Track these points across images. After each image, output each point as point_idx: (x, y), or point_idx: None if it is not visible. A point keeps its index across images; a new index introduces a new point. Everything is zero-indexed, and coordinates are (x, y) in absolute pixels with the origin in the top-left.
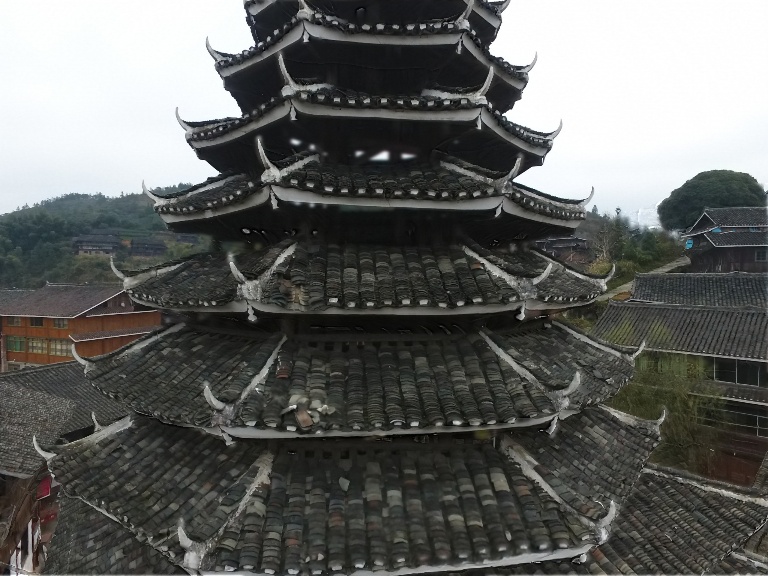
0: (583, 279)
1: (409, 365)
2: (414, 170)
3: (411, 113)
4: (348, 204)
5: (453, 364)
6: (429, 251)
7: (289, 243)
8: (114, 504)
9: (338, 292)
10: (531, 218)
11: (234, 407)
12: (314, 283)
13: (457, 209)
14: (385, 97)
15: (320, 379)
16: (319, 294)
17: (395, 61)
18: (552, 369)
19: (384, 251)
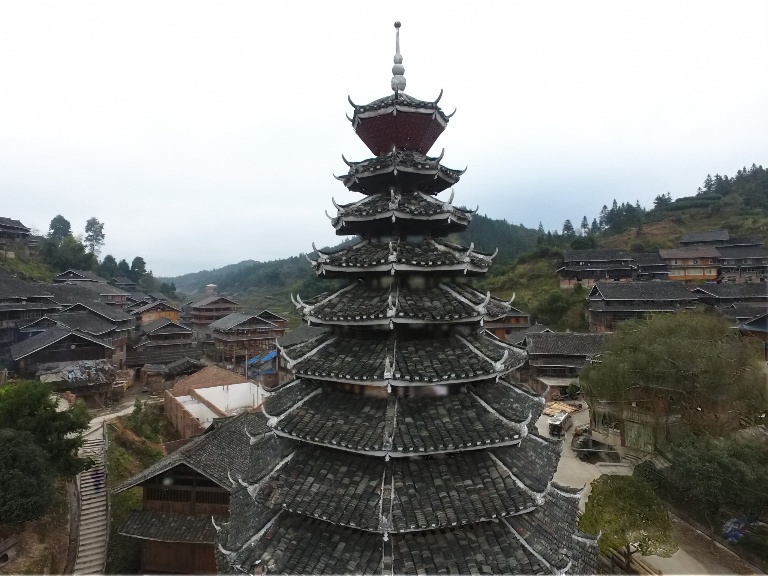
0: (522, 489)
1: (331, 548)
2: (367, 406)
3: (350, 380)
4: (307, 441)
5: (354, 555)
6: (364, 468)
7: (289, 453)
8: (219, 573)
9: (291, 498)
10: (435, 453)
11: (237, 553)
12: (284, 489)
13: (362, 453)
14: (361, 348)
15: (284, 544)
16: (282, 498)
17: (362, 328)
18: (432, 574)
19: (340, 463)
